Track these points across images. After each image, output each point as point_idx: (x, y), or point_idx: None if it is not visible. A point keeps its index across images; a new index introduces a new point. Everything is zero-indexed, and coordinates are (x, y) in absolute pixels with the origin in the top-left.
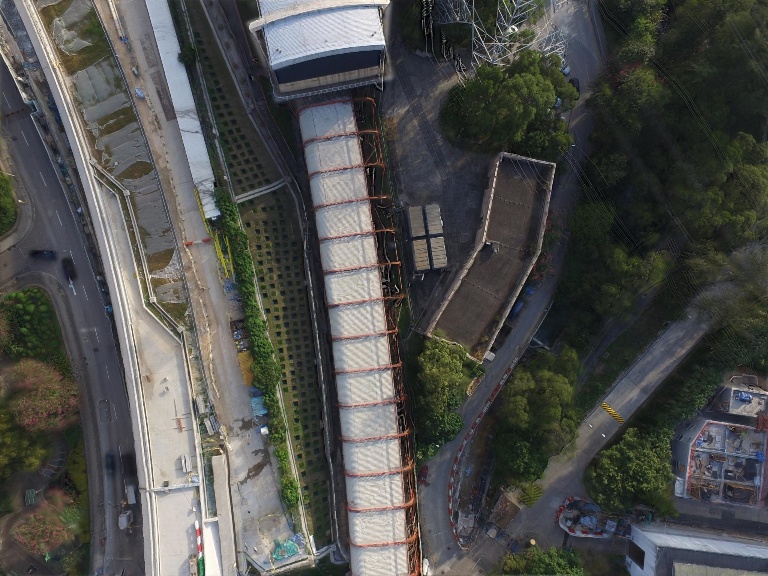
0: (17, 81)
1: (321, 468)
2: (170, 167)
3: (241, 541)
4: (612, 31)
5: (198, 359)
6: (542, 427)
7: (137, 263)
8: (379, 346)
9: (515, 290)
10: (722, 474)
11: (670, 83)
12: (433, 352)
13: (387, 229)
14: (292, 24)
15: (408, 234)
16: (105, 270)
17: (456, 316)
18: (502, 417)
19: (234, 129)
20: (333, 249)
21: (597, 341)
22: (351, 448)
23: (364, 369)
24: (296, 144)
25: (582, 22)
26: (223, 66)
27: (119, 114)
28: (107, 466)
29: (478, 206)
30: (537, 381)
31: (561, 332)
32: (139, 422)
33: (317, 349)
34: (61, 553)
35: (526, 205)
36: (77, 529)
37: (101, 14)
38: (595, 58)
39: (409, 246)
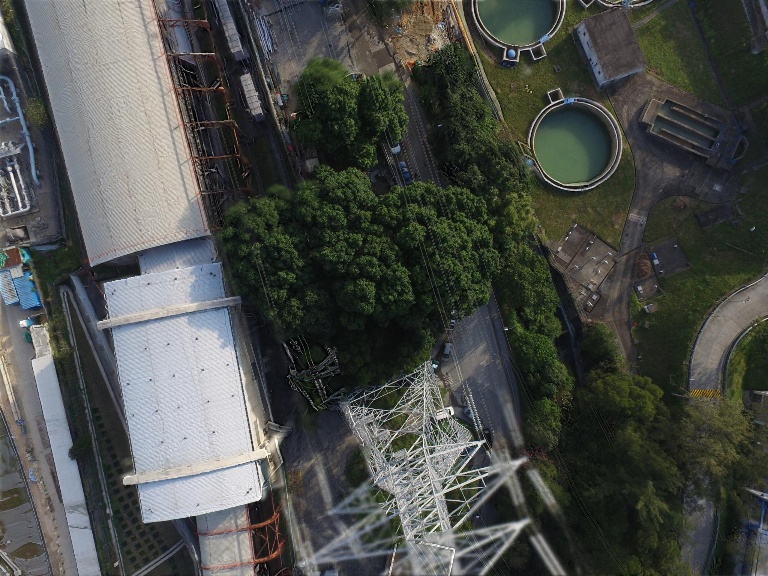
0: None
1: None
2: (61, 551)
3: None
4: (523, 393)
5: None
6: None
7: None
8: None
9: None
10: None
11: (570, 486)
12: None
13: None
14: (164, 485)
15: None
16: None
17: None
18: None
19: (130, 502)
20: None
21: None
22: None
23: None
24: None
25: (495, 372)
26: (122, 436)
27: (13, 493)
28: None
29: (382, 566)
30: None
31: None
32: None
33: None
34: None
35: None
36: None
37: None
38: (508, 409)
39: None
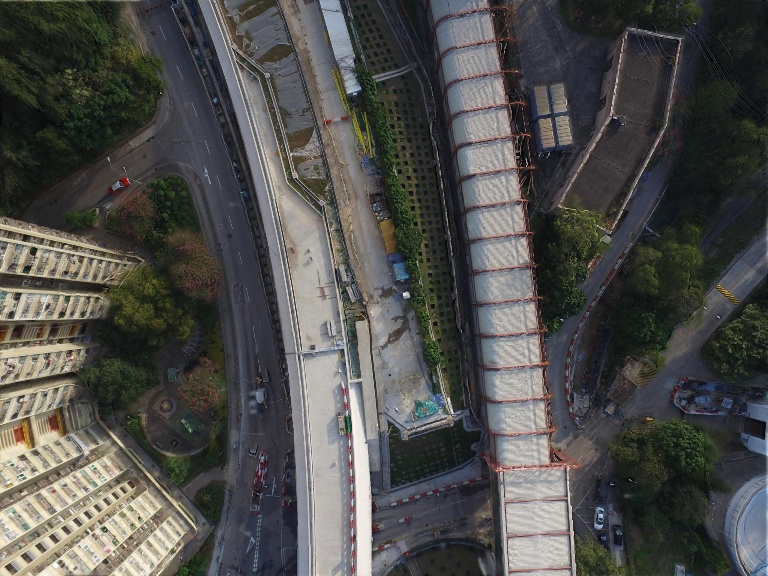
0: None
1: (453, 338)
2: (309, 48)
3: (382, 403)
4: None
5: (339, 231)
6: (668, 296)
7: (279, 142)
8: (514, 214)
9: (642, 163)
10: None
11: None
12: (570, 216)
13: (520, 102)
14: None
15: (530, 117)
16: (247, 151)
17: (584, 189)
18: (614, 303)
19: (366, 13)
20: (470, 120)
21: (711, 225)
22: (489, 311)
23: (501, 235)
24: (420, 31)
25: None
26: None
27: None
28: (242, 346)
29: (597, 89)
30: (664, 251)
31: (673, 219)
32: (286, 290)
33: (446, 226)
34: (201, 428)
35: (650, 81)
36: (217, 404)
37: None
38: None
39: (531, 129)
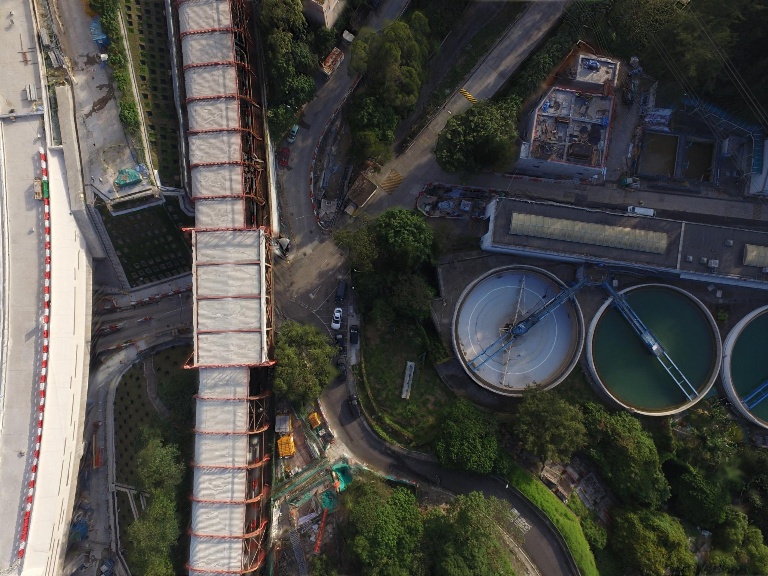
0: None
1: (170, 117)
2: None
3: (88, 174)
4: None
5: None
6: (385, 77)
7: None
8: None
9: None
10: (566, 138)
11: None
12: None
13: None
14: None
15: None
16: None
17: None
18: None
19: None
20: None
21: (458, 28)
22: (189, 75)
23: None
24: None
25: None
26: None
27: None
28: None
29: None
30: (380, 30)
31: None
32: None
33: (167, 3)
34: None
35: None
36: None
37: None
38: None
39: None
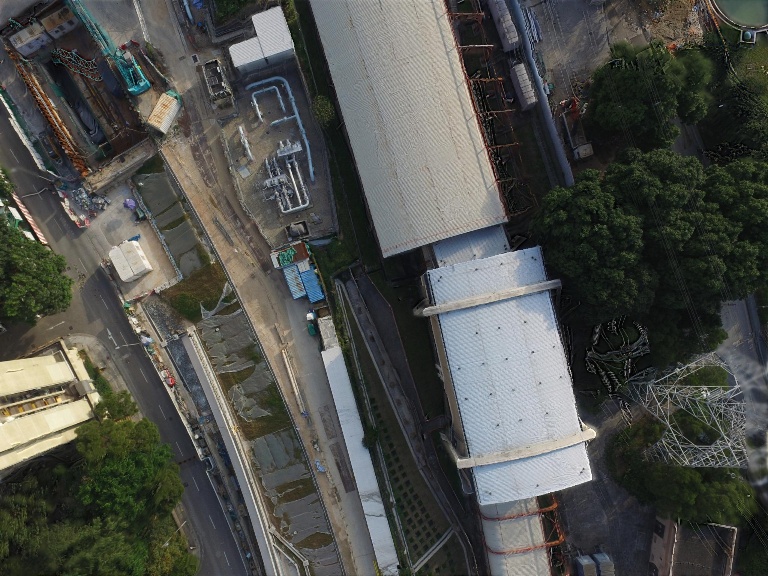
0: (194, 440)
1: None
2: (350, 540)
3: None
4: None
5: None
6: None
7: None
8: None
9: None
10: None
11: None
12: None
13: None
14: (502, 467)
15: None
16: None
17: None
18: None
19: (408, 491)
20: None
21: None
22: None
23: None
24: None
25: (746, 352)
26: (396, 425)
27: (298, 484)
28: None
29: (646, 548)
30: None
31: None
32: None
33: None
34: None
35: (705, 566)
36: None
37: (282, 388)
38: (761, 388)
39: None
